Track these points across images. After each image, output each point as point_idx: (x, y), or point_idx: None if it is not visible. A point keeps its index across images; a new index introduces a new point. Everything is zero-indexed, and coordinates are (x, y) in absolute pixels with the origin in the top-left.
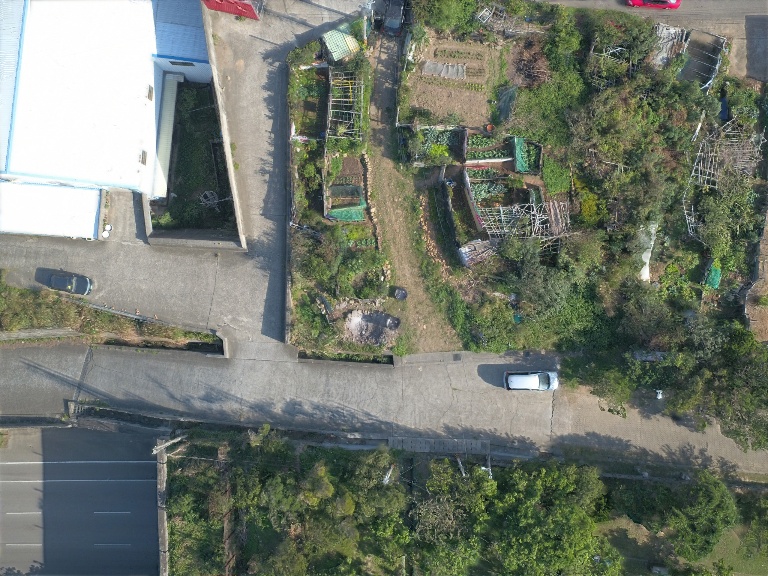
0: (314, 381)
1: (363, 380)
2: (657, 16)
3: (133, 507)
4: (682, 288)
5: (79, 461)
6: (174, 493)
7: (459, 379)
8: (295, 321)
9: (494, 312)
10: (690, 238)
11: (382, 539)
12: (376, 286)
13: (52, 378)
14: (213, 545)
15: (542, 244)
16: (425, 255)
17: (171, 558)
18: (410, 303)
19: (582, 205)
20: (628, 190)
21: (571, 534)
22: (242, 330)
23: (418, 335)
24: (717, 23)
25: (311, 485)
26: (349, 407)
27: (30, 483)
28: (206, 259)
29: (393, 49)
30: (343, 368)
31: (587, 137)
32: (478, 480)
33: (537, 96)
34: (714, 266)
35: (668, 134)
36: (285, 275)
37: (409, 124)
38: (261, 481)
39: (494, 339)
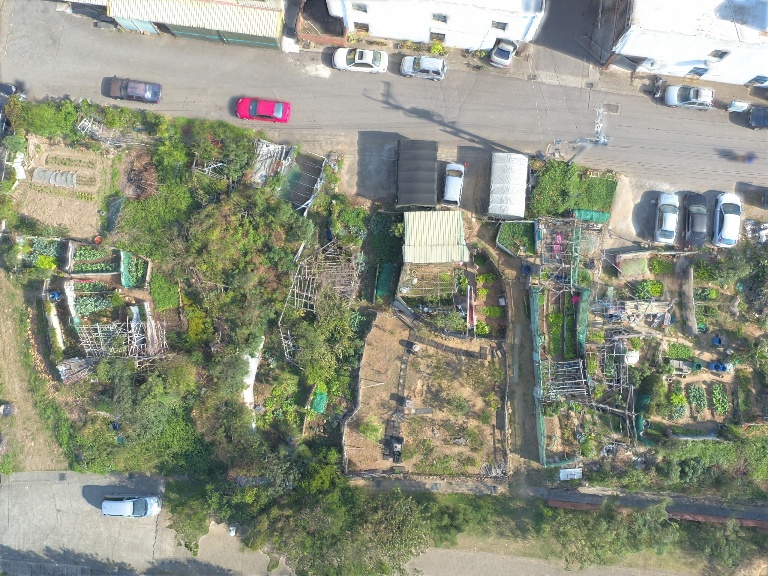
0: None
1: None
2: (269, 129)
3: None
4: (287, 412)
5: None
6: None
7: (64, 500)
8: None
9: (96, 432)
10: (290, 362)
11: None
12: None
13: None
14: None
15: (140, 364)
16: (33, 369)
17: None
18: (19, 418)
19: (189, 322)
20: (227, 311)
21: None
22: None
23: (26, 452)
24: (329, 138)
25: None
26: None
27: None
28: None
29: (2, 154)
30: None
31: (185, 255)
32: None
33: (144, 208)
34: (320, 390)
35: (267, 254)
36: None
37: (10, 234)
38: None
39: (94, 461)
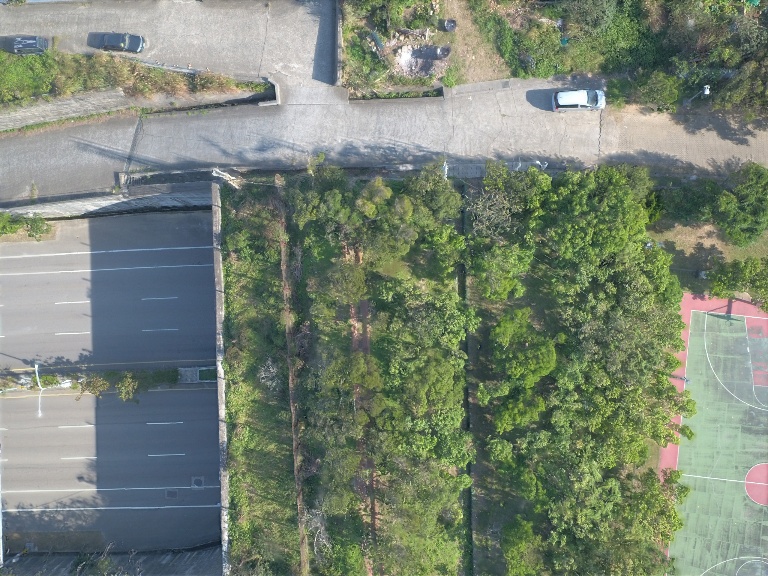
0: (365, 121)
1: (414, 114)
2: None
3: (180, 292)
4: (724, 6)
5: (126, 250)
6: (229, 234)
7: (508, 105)
8: (346, 60)
9: (542, 36)
10: None
11: (439, 244)
12: (425, 20)
13: (102, 153)
14: (268, 283)
15: None
16: None
17: (227, 299)
18: (459, 35)
19: None
20: None
21: (626, 213)
22: (293, 76)
23: (467, 66)
24: None
25: (369, 193)
26: (400, 142)
27: (78, 273)
28: (257, 10)
29: None
30: (394, 105)
31: None
32: (533, 175)
33: None
34: None
35: None
36: (335, 18)
37: None
38: (320, 194)
39: (542, 61)
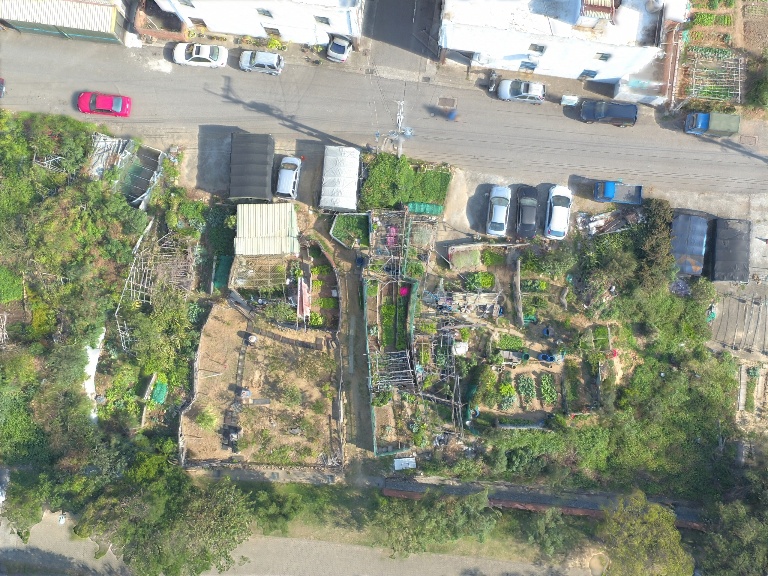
0: None
1: None
2: (111, 123)
3: None
4: (128, 402)
5: None
6: None
7: None
8: None
9: None
10: None
11: None
12: None
13: None
14: None
15: None
16: None
17: None
18: None
19: (33, 314)
20: (66, 302)
21: None
22: None
23: None
24: (170, 132)
25: None
26: None
27: None
28: None
29: None
30: None
31: (25, 247)
32: None
33: None
34: (161, 380)
35: (105, 246)
36: None
37: None
38: None
39: None
